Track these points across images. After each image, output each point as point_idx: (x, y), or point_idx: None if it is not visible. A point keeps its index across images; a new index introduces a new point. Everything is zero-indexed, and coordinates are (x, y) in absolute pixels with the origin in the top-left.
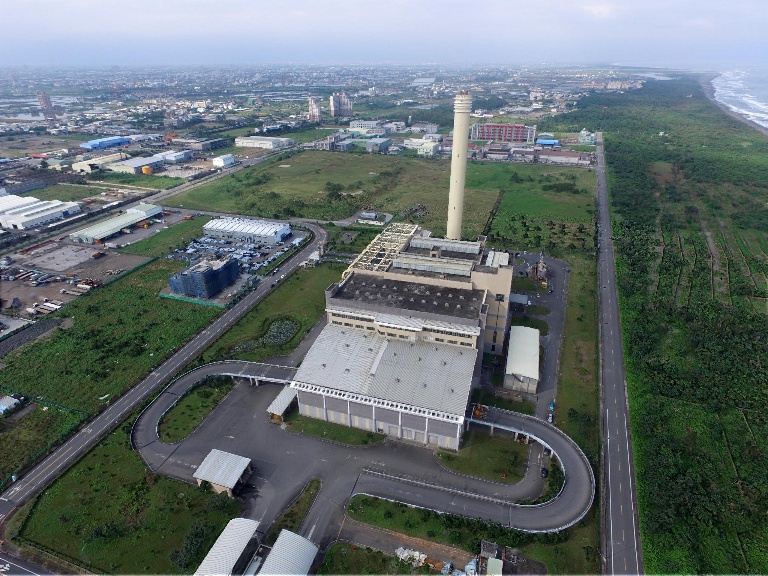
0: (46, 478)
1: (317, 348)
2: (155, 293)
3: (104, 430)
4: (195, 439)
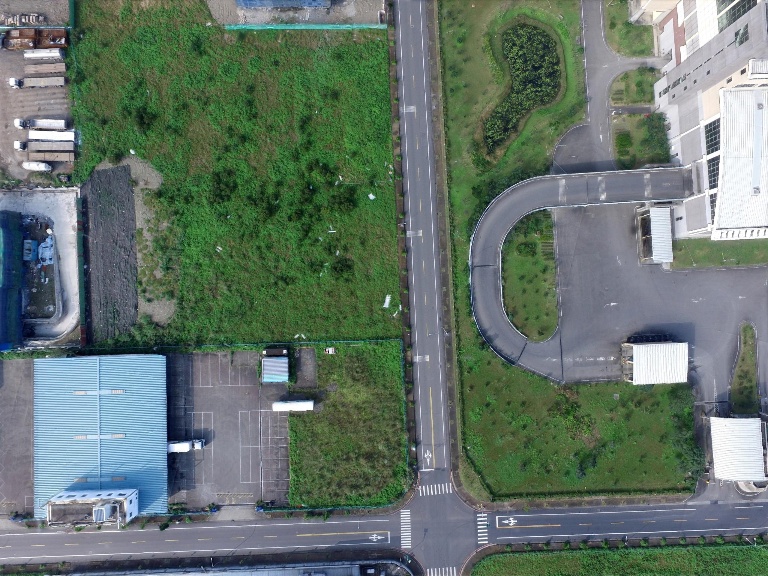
0: (446, 432)
1: (734, 157)
2: (207, 23)
3: (443, 350)
4: (572, 323)
